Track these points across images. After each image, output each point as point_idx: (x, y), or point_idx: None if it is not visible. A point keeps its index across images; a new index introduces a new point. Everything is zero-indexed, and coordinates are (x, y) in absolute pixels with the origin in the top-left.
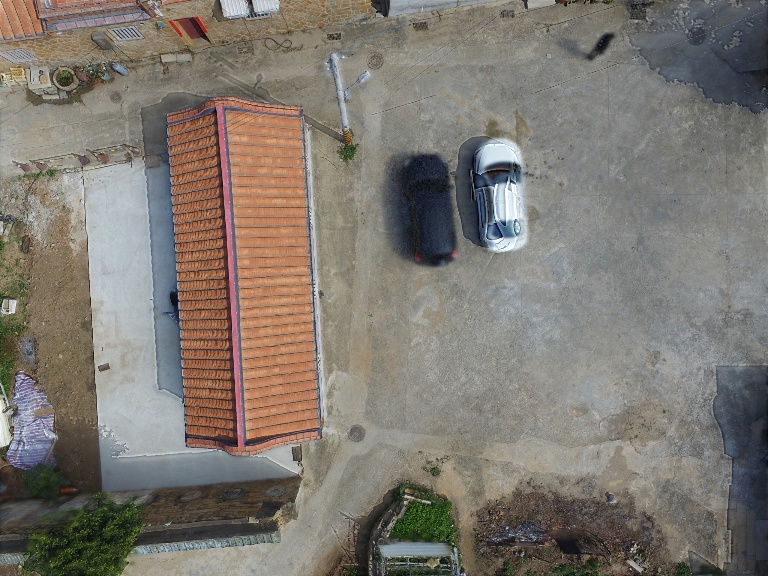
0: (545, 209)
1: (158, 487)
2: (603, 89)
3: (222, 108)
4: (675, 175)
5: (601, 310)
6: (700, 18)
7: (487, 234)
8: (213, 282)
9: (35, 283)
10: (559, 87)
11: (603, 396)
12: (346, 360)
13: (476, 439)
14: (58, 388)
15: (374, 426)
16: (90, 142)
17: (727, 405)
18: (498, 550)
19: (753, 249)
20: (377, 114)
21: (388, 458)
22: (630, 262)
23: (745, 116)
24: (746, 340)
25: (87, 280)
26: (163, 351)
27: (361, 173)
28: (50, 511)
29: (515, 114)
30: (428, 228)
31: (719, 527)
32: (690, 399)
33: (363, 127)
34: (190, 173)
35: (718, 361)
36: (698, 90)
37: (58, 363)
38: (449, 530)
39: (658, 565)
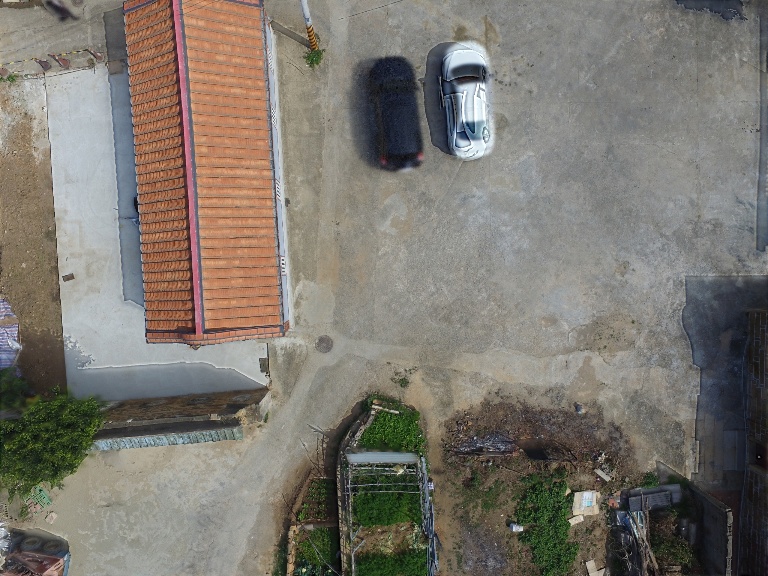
0: (514, 116)
1: (124, 399)
2: None
3: None
4: (646, 82)
5: (570, 219)
6: None
7: (456, 142)
8: (171, 171)
9: None
10: None
11: (572, 306)
12: (313, 269)
13: (444, 350)
14: (22, 298)
15: (342, 337)
16: (52, 47)
17: (696, 315)
18: (466, 459)
19: (723, 158)
20: (344, 19)
21: (356, 369)
22: (600, 171)
23: (717, 23)
24: (716, 250)
25: (50, 189)
26: (128, 261)
27: (328, 79)
28: (12, 416)
29: (484, 20)
30: (396, 135)
31: (687, 437)
32: (659, 309)
33: (330, 32)
34: (147, 61)
35: (687, 271)
36: None
37: (21, 272)
38: (417, 440)
39: (626, 475)
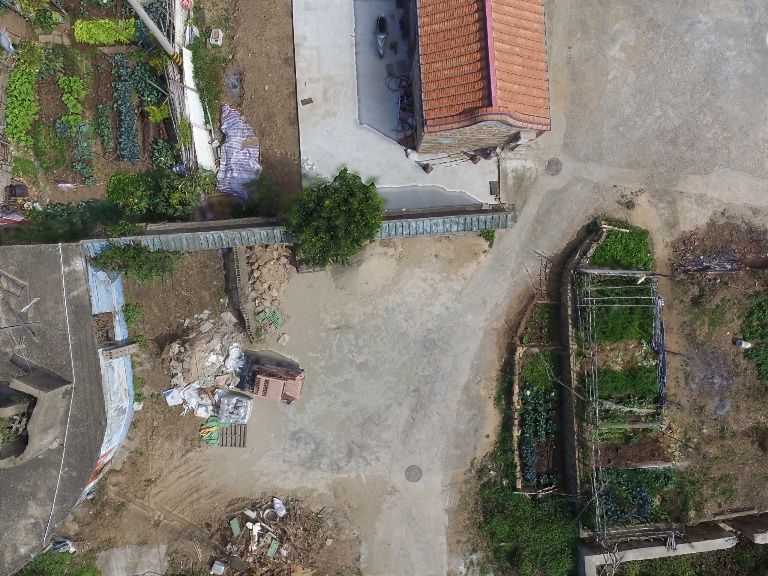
0: None
1: None
2: None
3: None
4: None
5: None
6: None
7: None
8: None
9: (242, 16)
10: None
11: None
12: None
13: (670, 172)
14: (263, 120)
15: (571, 159)
16: None
17: None
18: (694, 277)
19: None
20: None
21: (583, 192)
22: None
23: None
24: None
25: (290, 17)
26: (364, 87)
27: None
28: None
29: None
30: None
31: None
32: None
33: None
34: None
35: None
36: None
37: (264, 95)
38: (646, 258)
39: None
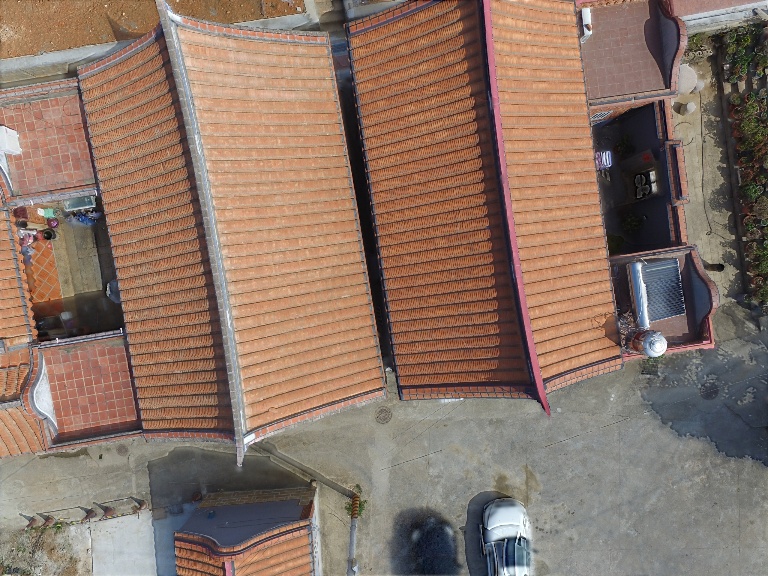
0: (555, 564)
1: None
2: (614, 443)
3: (231, 562)
4: (687, 529)
5: None
6: (713, 373)
7: None
8: None
9: None
10: (569, 441)
11: None
12: None
13: None
14: None
15: None
16: (97, 495)
17: None
18: None
19: None
20: (385, 469)
21: None
22: None
23: (758, 470)
24: None
25: None
26: None
27: (369, 529)
28: None
29: (525, 468)
30: None
31: None
32: None
33: (371, 483)
34: None
35: None
36: (711, 444)
37: None
38: None
39: None
